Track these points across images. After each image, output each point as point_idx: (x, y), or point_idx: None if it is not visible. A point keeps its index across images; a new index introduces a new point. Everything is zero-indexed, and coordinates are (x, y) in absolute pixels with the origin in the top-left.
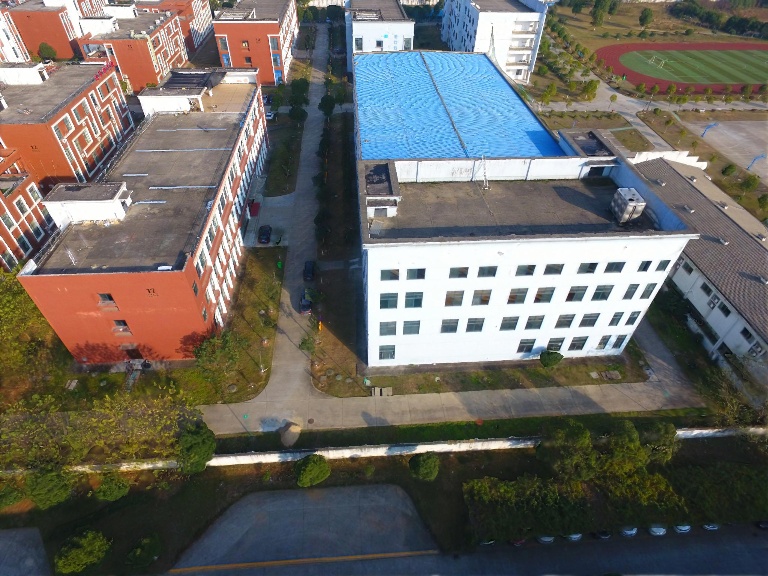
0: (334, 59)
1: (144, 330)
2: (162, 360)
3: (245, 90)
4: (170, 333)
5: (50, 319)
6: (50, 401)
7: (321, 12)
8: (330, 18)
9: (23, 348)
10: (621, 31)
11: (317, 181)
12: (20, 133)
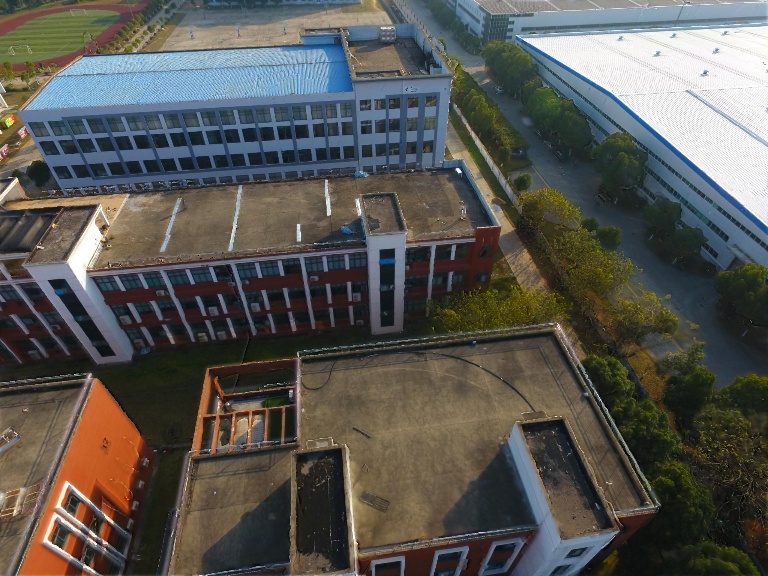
0: None
1: None
2: None
3: (32, 207)
4: None
5: None
6: None
7: None
8: None
9: None
10: None
11: None
12: (86, 440)
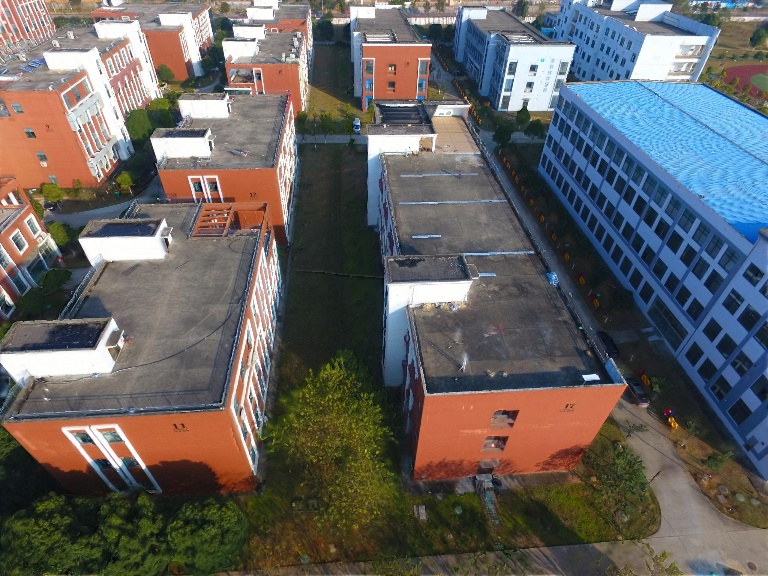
0: (458, 82)
1: (521, 445)
2: (511, 474)
3: (455, 125)
4: (547, 447)
5: (423, 438)
6: (505, 572)
7: None
8: (432, 37)
9: (384, 474)
10: (732, 52)
11: (560, 230)
12: (243, 179)
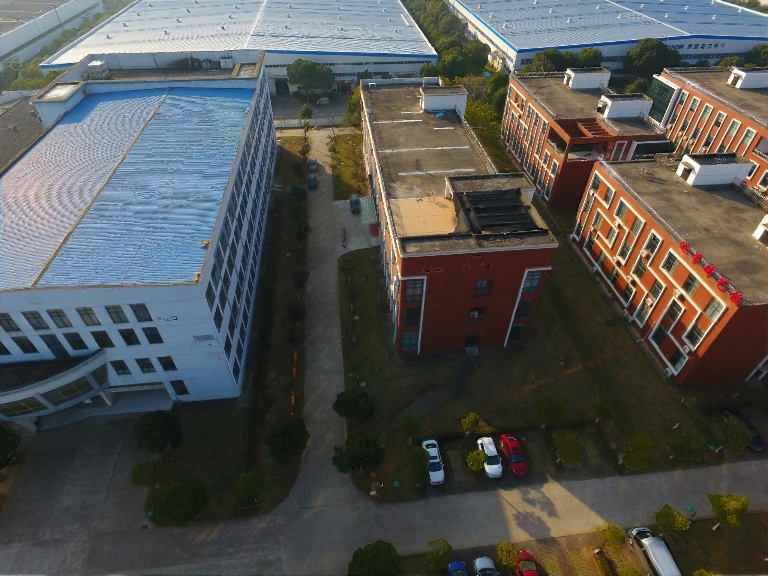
0: None
1: None
2: None
3: None
4: None
5: None
6: None
7: None
8: None
9: None
10: None
11: None
12: None
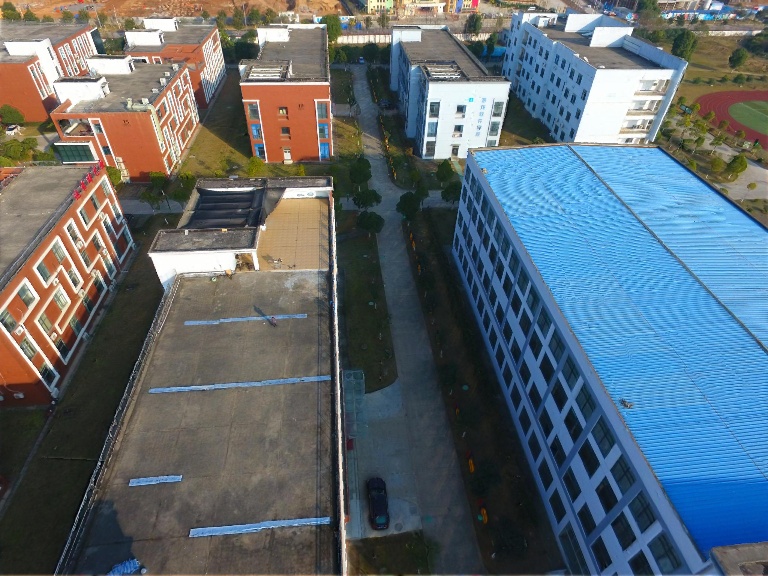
0: (384, 117)
1: None
2: None
3: (313, 213)
4: None
5: None
6: None
7: (354, 51)
8: (367, 60)
9: None
10: (709, 74)
11: (447, 379)
12: None
